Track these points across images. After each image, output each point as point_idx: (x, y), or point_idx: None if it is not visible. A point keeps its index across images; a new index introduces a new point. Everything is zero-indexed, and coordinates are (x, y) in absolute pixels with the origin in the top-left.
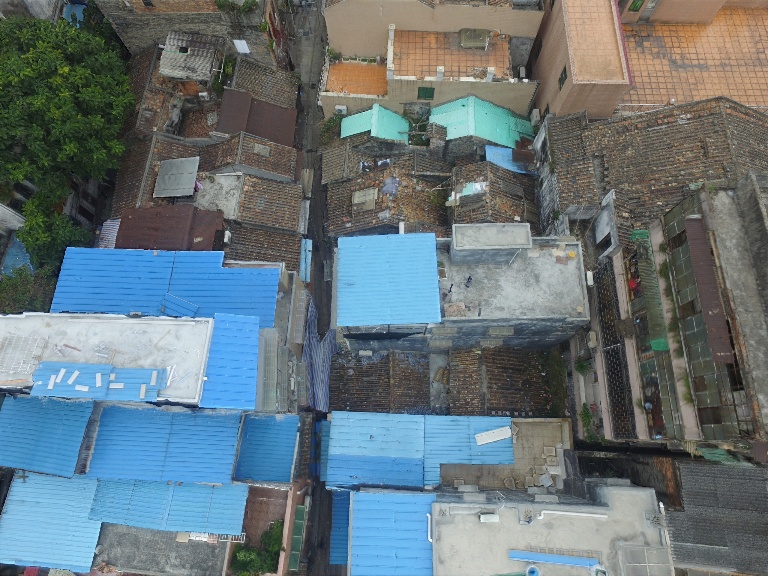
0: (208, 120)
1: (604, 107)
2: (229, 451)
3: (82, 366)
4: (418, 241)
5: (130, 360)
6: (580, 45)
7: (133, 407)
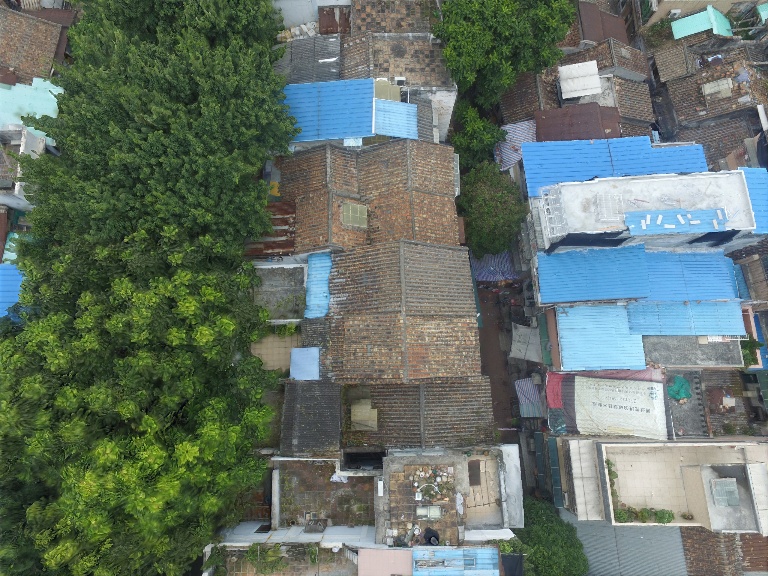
0: None
1: None
2: (726, 277)
3: (661, 212)
4: None
5: (690, 205)
6: None
7: (650, 251)
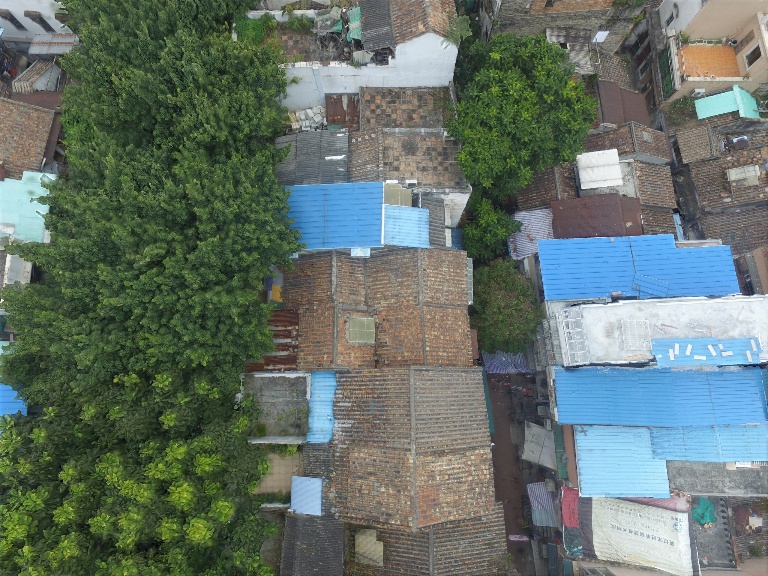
0: None
1: None
2: (756, 398)
3: (690, 340)
4: None
5: (722, 333)
6: None
7: (676, 370)
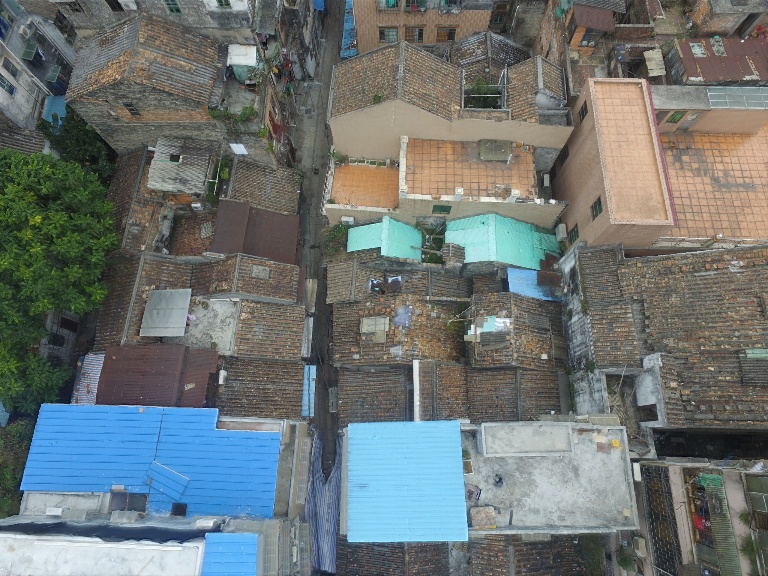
0: (202, 232)
1: (642, 240)
2: None
3: None
4: (440, 431)
5: None
6: (616, 174)
7: None
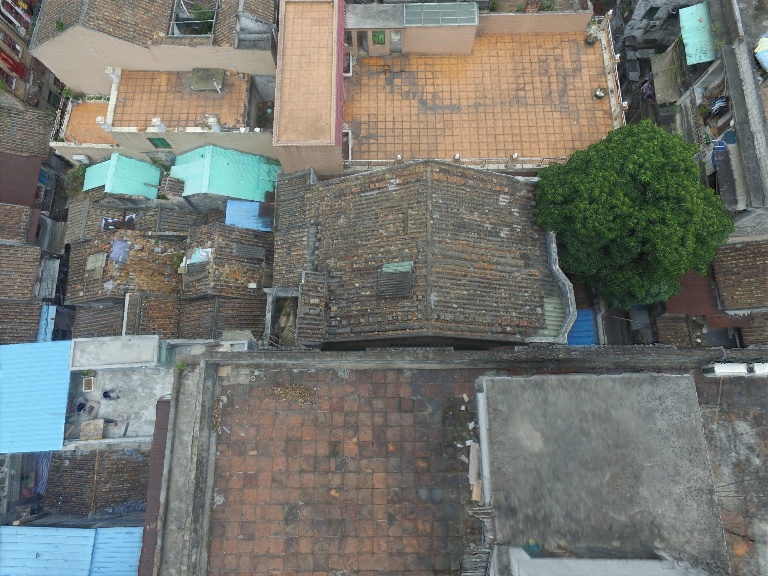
0: None
1: (328, 164)
2: None
3: None
4: (55, 351)
5: None
6: (291, 96)
7: None
